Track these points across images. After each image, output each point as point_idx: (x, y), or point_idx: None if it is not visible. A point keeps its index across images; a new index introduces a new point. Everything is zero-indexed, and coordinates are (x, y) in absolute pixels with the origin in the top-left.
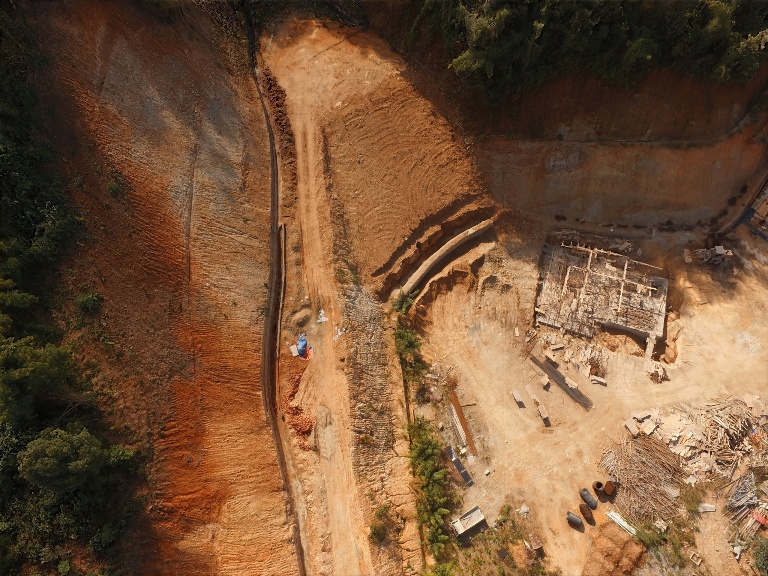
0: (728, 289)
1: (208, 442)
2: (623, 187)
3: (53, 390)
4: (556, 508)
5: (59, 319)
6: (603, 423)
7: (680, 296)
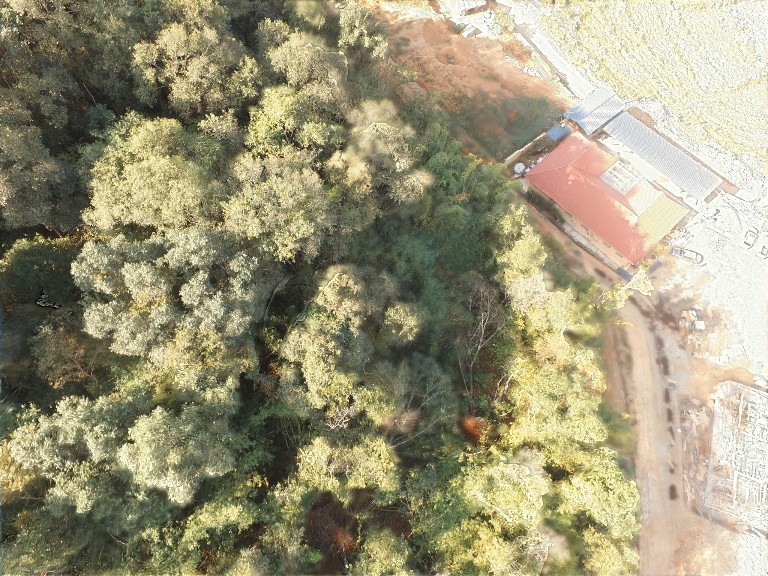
0: (722, 321)
1: None
2: (649, 417)
3: None
4: None
5: None
6: None
7: (740, 370)
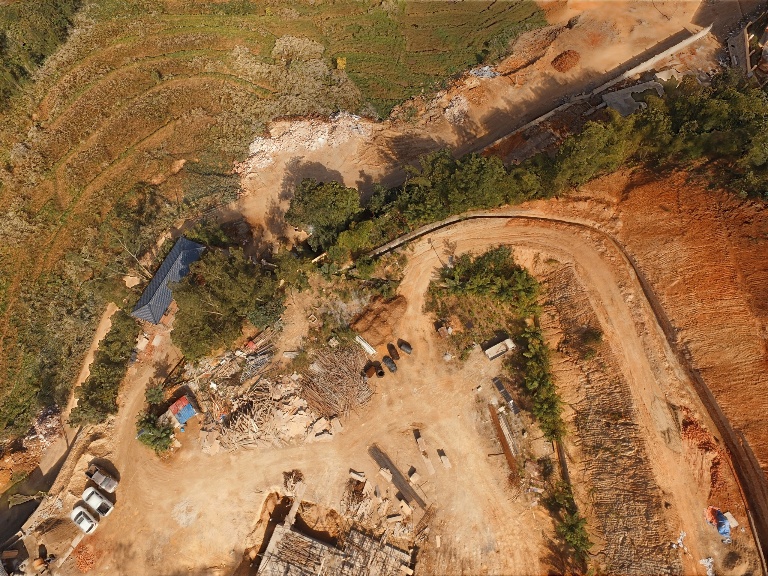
0: None
1: None
2: None
3: None
4: (419, 358)
5: None
6: (362, 431)
7: None
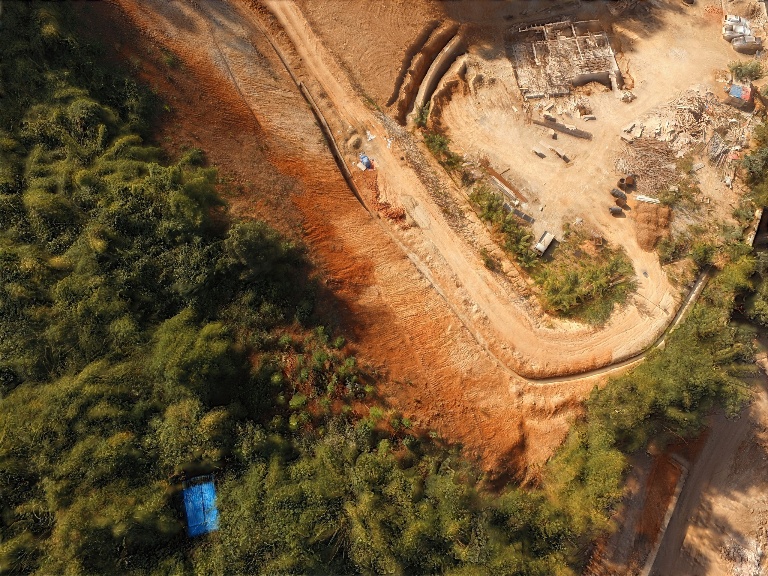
0: (648, 23)
1: (340, 233)
2: None
3: (211, 216)
4: (600, 210)
5: None
6: (605, 144)
7: (618, 40)
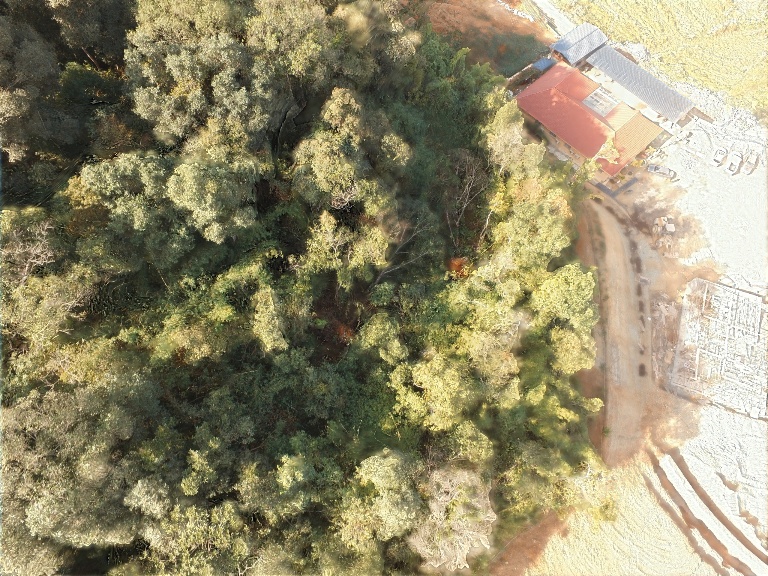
0: (691, 228)
1: None
2: (621, 302)
3: None
4: None
5: None
6: None
7: (707, 270)
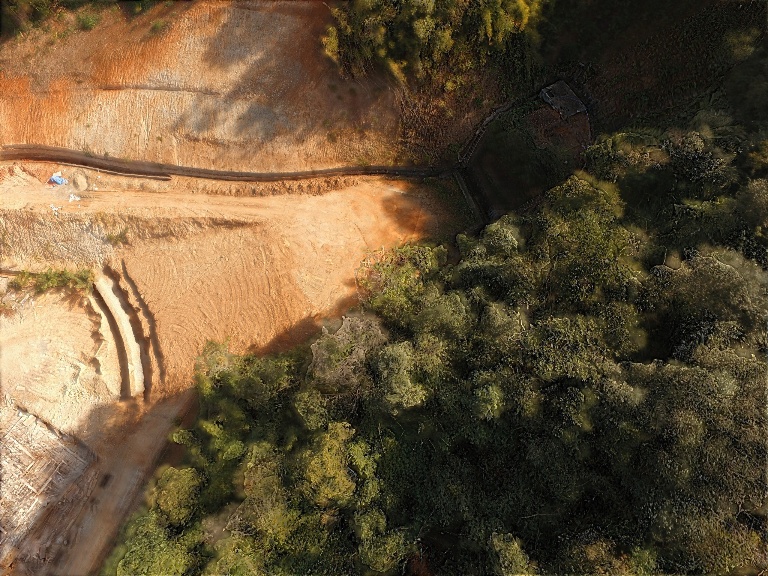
0: None
1: None
2: (85, 569)
3: None
4: None
5: (87, 6)
6: None
7: None
